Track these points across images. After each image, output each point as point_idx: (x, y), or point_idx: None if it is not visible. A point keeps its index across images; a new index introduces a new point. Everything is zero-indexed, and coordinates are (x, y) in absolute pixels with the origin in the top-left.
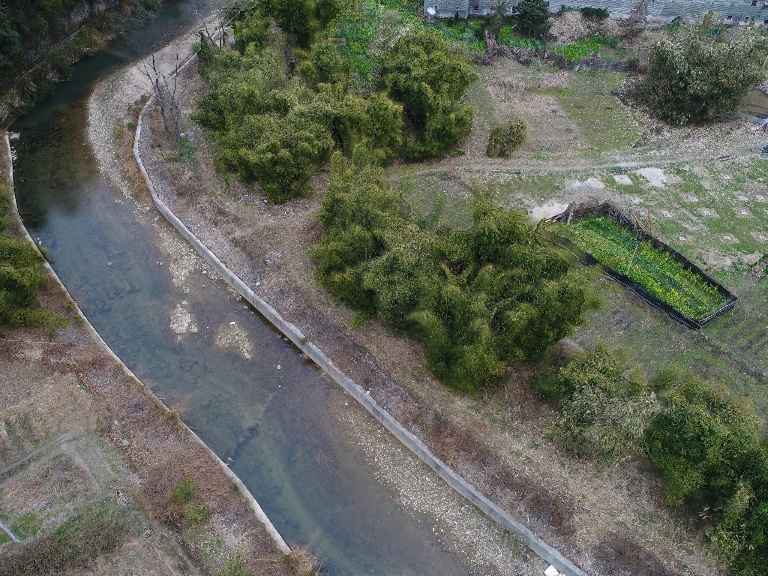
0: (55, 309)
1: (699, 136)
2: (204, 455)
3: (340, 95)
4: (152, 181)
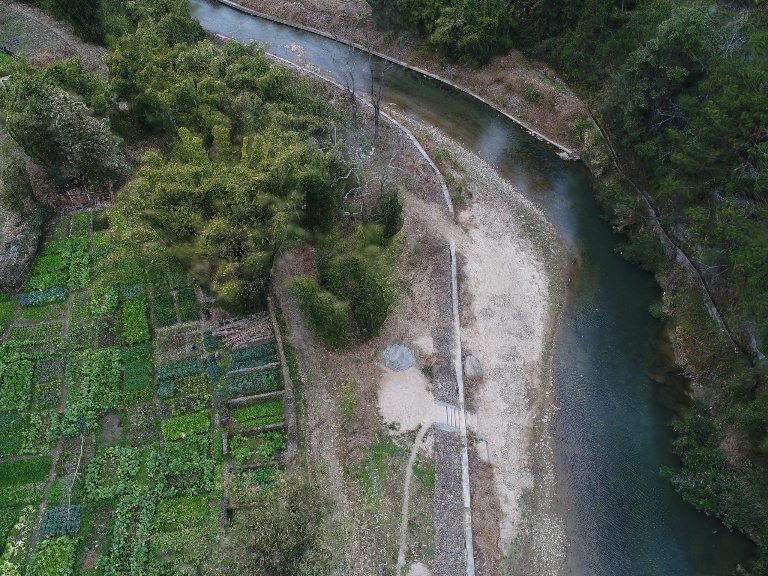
0: None
1: None
2: (260, 8)
3: None
4: (367, 105)
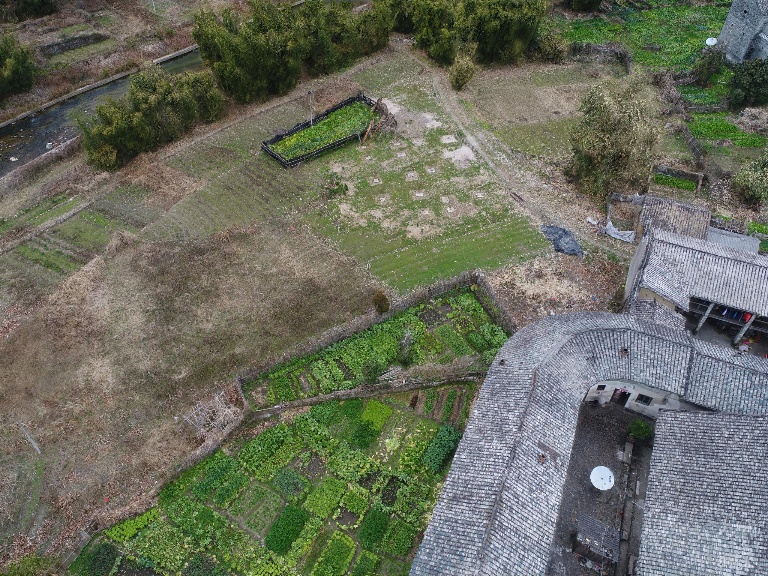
0: (277, 0)
1: (552, 184)
2: None
3: (461, 1)
4: None
